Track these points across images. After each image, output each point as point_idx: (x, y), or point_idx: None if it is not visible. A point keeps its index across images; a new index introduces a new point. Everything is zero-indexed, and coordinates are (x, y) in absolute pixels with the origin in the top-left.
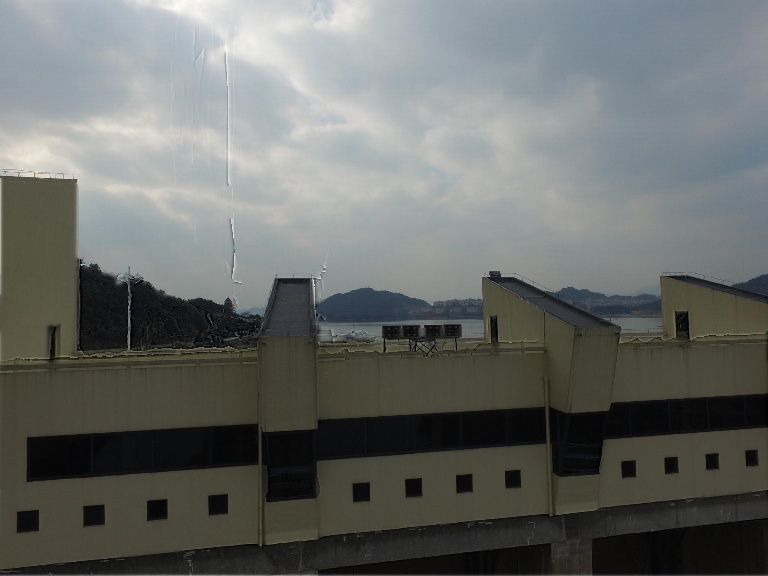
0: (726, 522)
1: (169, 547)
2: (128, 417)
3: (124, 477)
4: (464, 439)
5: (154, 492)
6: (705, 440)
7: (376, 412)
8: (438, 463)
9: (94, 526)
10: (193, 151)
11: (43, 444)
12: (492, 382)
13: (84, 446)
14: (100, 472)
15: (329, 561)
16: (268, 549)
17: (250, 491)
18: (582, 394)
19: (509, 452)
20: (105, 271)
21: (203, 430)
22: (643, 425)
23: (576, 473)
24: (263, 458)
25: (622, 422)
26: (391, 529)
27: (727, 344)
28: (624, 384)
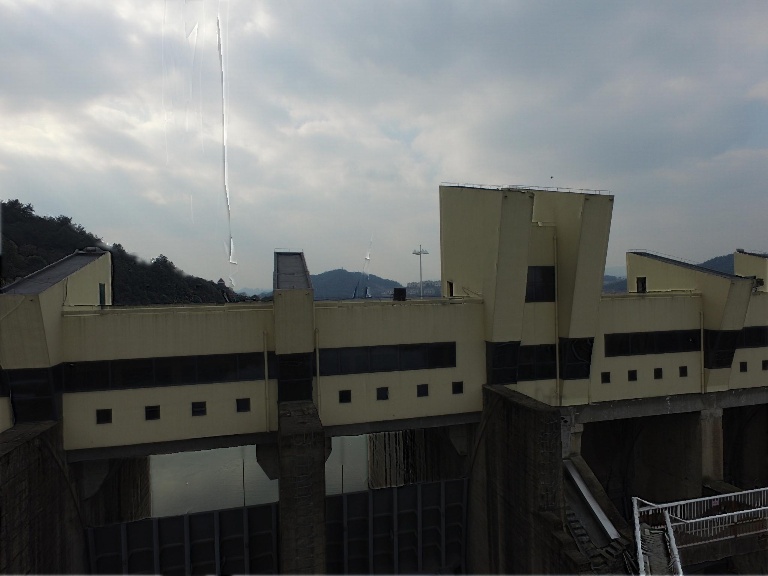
0: None
1: (663, 393)
2: (645, 324)
3: (644, 356)
4: None
5: (657, 364)
6: None
7: (749, 324)
8: None
9: (632, 381)
10: (188, 130)
11: (609, 338)
12: None
13: (626, 339)
14: (634, 353)
15: (727, 404)
16: (701, 396)
17: (696, 365)
18: None
19: None
20: (129, 251)
21: (676, 332)
22: None
23: None
24: (704, 347)
25: None
26: (756, 387)
27: None
28: None
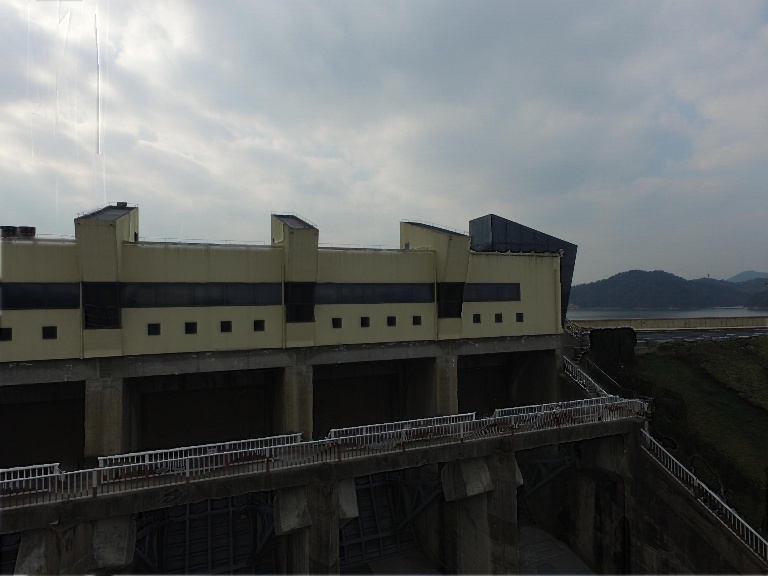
0: (239, 369)
1: None
2: None
3: None
4: (6, 303)
5: None
6: (221, 312)
7: None
8: None
9: None
10: None
11: None
12: (33, 262)
13: None
14: None
15: None
16: None
17: None
18: (92, 268)
19: (47, 313)
20: None
21: None
22: (171, 300)
23: (99, 327)
24: None
25: (151, 297)
26: None
27: (244, 247)
28: (154, 270)
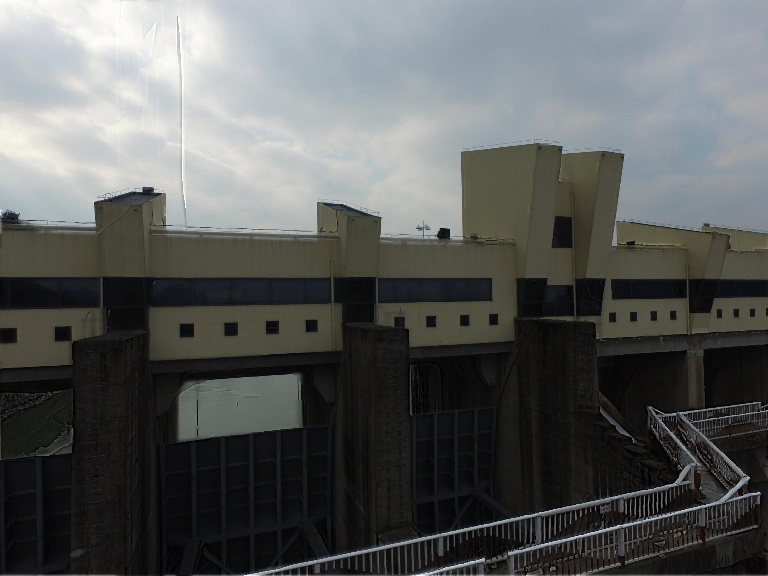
0: None
1: (658, 333)
2: (643, 273)
3: (642, 300)
4: (752, 292)
5: (652, 308)
6: None
7: (723, 277)
8: (744, 303)
9: (634, 321)
10: (143, 130)
11: (615, 283)
12: (761, 267)
13: (628, 285)
14: (634, 297)
15: (707, 345)
16: (687, 338)
17: (683, 310)
18: None
19: (767, 300)
20: None
21: (667, 281)
22: None
23: None
24: (689, 295)
25: None
26: (729, 331)
27: None
28: None
